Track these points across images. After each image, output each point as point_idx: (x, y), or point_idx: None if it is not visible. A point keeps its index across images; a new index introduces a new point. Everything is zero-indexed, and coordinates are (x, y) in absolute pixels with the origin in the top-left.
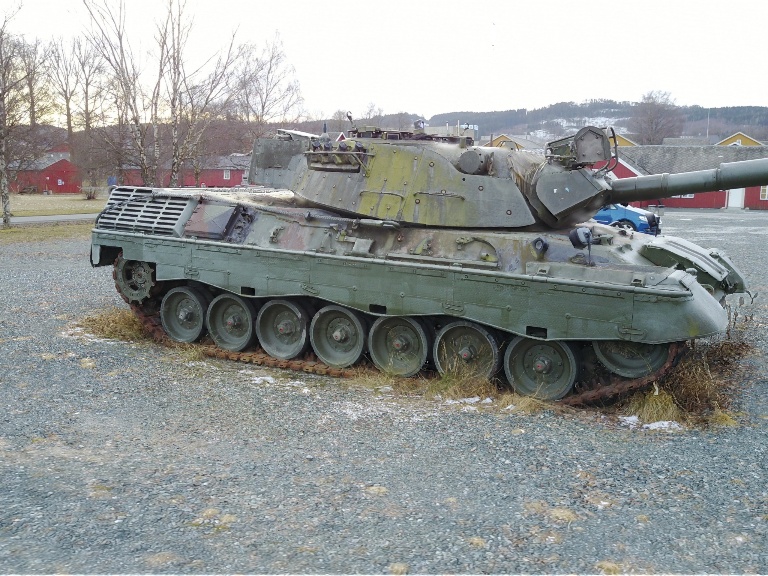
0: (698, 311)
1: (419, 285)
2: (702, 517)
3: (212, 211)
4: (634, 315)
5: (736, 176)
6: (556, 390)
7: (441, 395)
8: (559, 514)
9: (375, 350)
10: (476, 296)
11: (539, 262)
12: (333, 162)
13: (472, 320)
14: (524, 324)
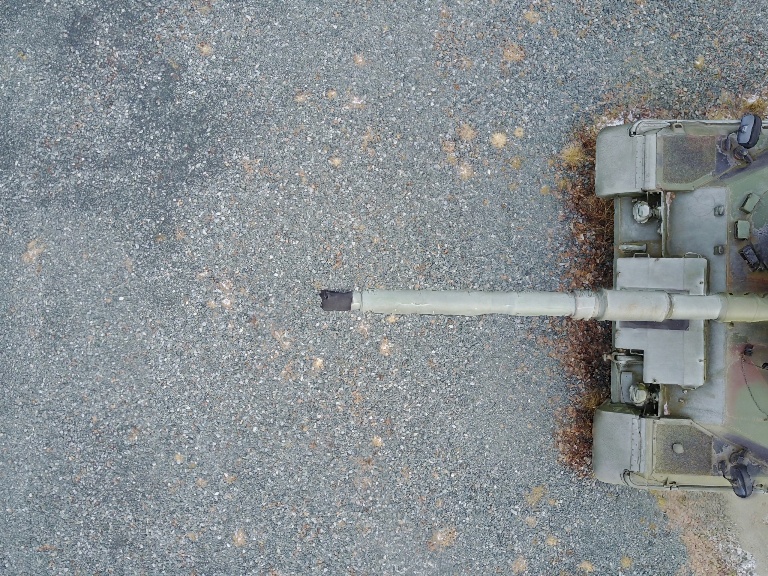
0: None
1: None
2: None
3: None
4: None
5: None
6: None
7: None
8: None
9: None
10: None
11: None
12: None
13: None
14: None
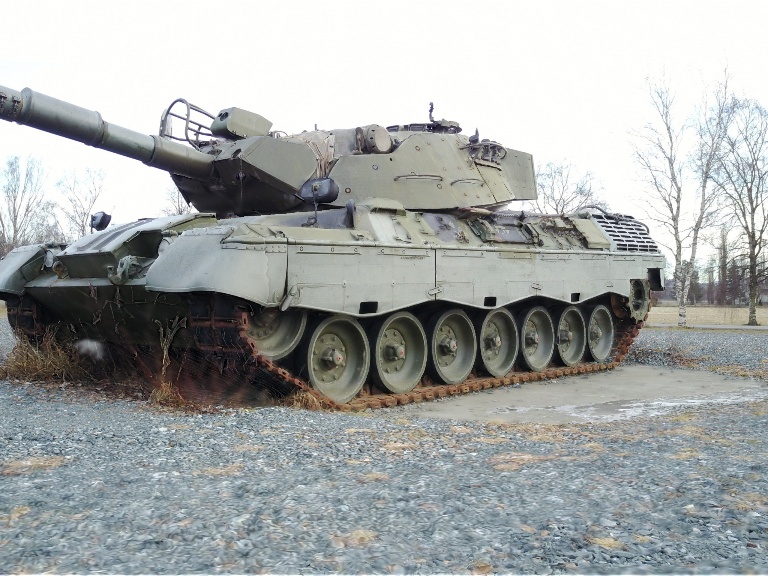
0: None
1: None
2: None
3: None
4: None
5: None
6: None
7: None
8: None
9: None
10: None
11: None
12: None
13: None
14: None
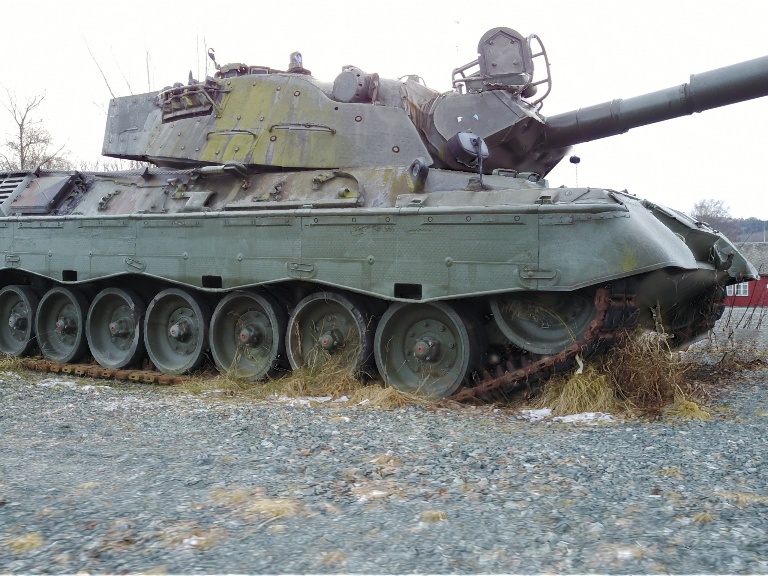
0: (635, 232)
1: (259, 241)
2: (564, 516)
3: (45, 183)
4: (540, 249)
5: (711, 86)
6: (446, 385)
7: (278, 393)
8: (265, 505)
9: (218, 346)
10: (329, 247)
11: (415, 193)
12: (184, 107)
13: (325, 283)
14: (391, 281)
